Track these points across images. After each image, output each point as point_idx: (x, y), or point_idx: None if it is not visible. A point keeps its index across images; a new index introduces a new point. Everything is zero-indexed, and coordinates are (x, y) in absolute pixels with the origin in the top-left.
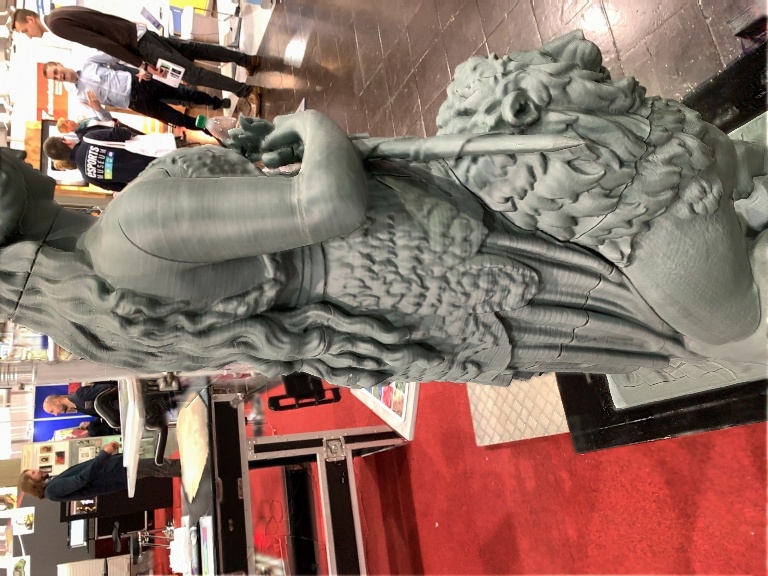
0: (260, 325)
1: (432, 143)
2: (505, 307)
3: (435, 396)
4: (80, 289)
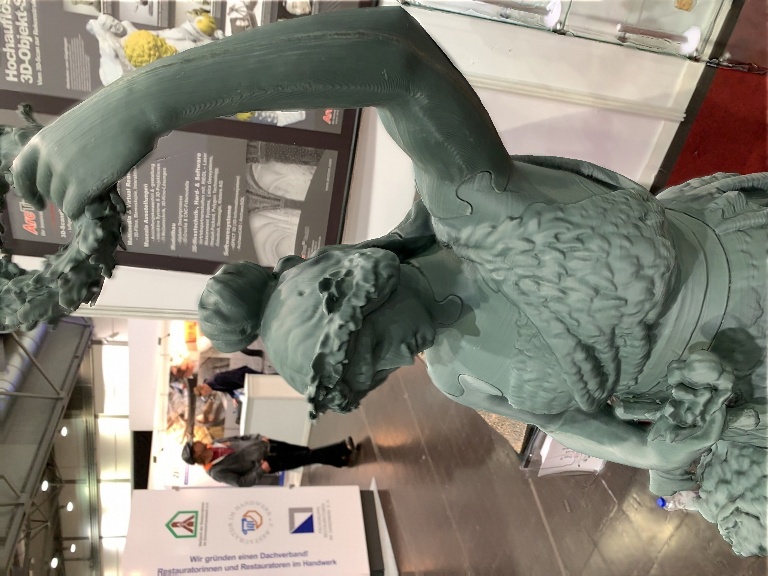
0: None
1: None
2: None
3: None
4: None
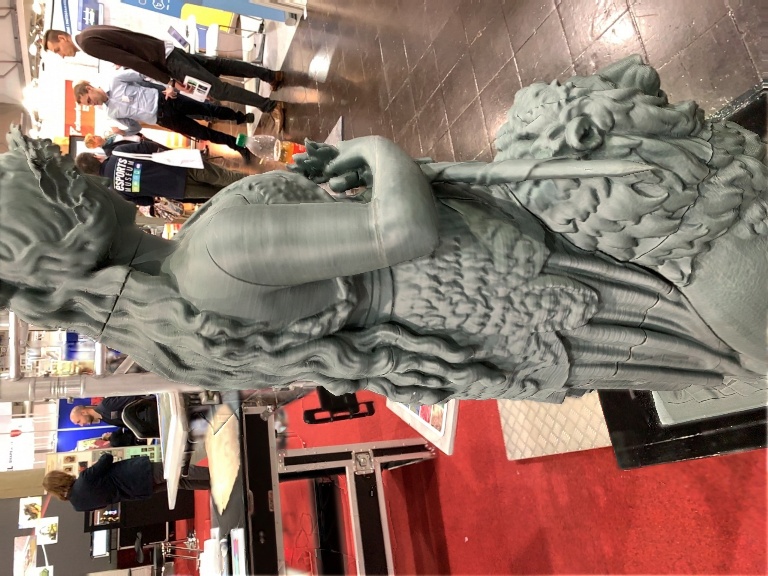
0: (333, 345)
1: (499, 168)
2: (566, 326)
3: (464, 409)
4: (166, 311)
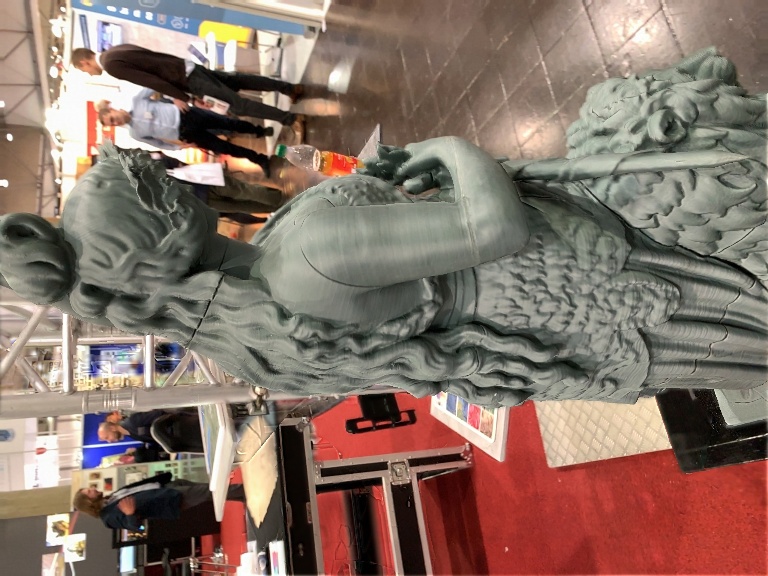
0: (420, 346)
1: (583, 163)
2: (648, 323)
3: None
4: (259, 315)
